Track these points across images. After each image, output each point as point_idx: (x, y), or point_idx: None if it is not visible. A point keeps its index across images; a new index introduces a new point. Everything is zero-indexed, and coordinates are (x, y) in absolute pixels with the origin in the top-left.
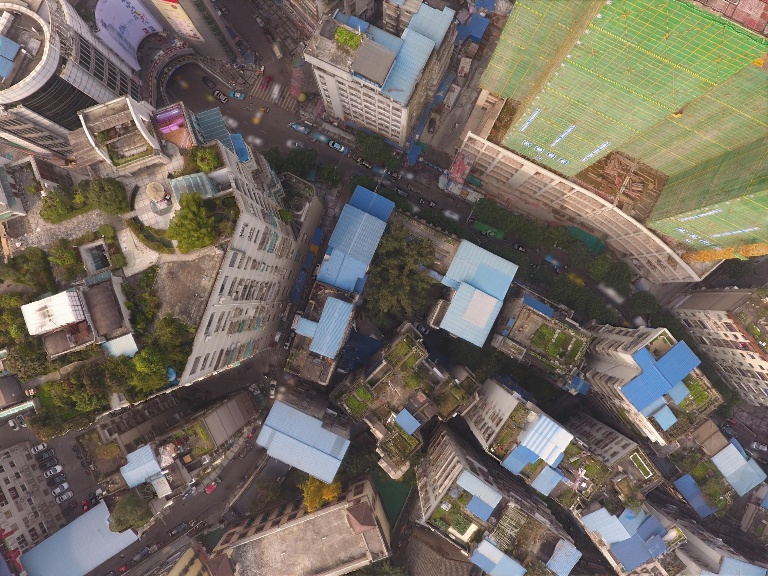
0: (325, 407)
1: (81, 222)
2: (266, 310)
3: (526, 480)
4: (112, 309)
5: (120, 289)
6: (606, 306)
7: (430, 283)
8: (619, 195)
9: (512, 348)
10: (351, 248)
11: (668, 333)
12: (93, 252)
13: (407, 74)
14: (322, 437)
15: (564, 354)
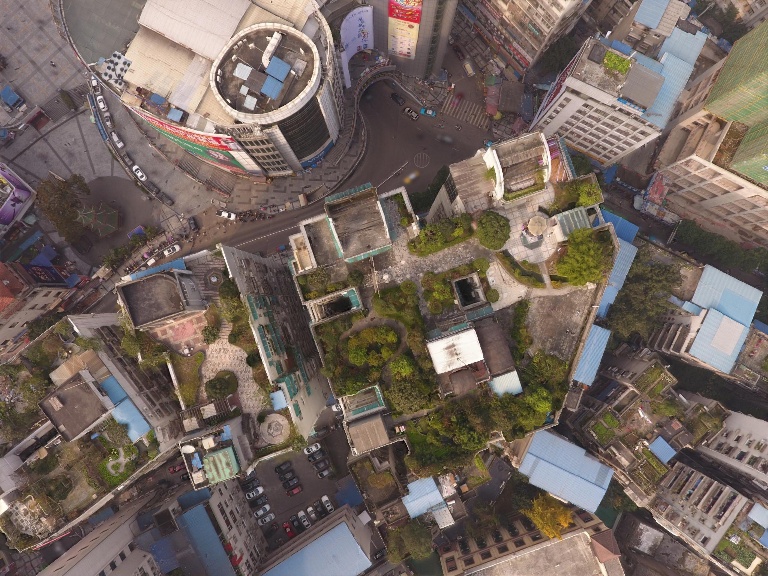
0: (557, 432)
1: (447, 255)
2: None
3: None
4: (506, 346)
5: None
6: None
7: (667, 308)
8: None
9: (746, 374)
10: None
11: None
12: None
13: (665, 98)
14: (586, 466)
15: None
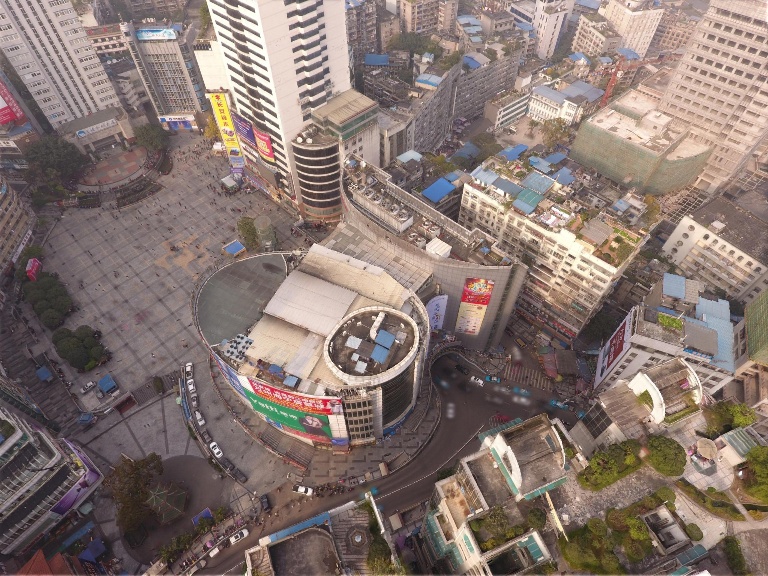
0: None
1: (622, 488)
2: None
3: None
4: None
5: None
6: None
7: None
8: None
9: None
10: None
11: None
12: None
13: (723, 348)
14: None
15: None
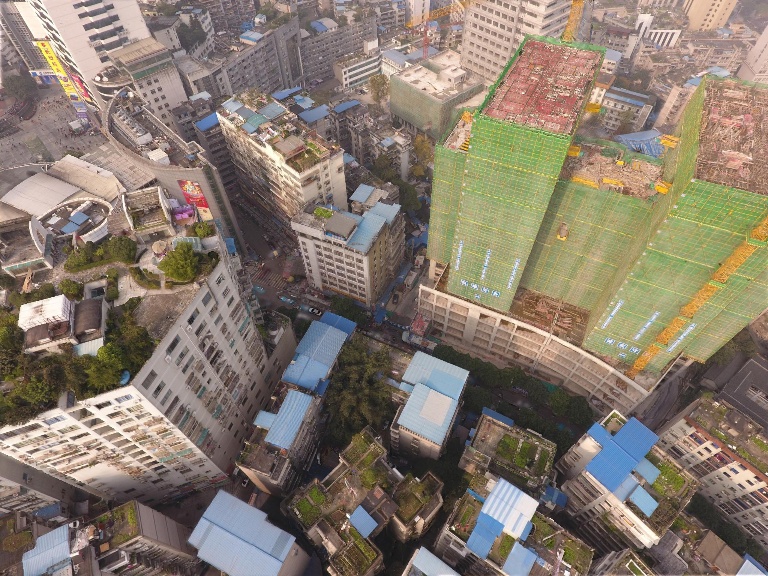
0: None
1: (93, 272)
2: (229, 406)
3: (499, 573)
4: (95, 315)
5: (106, 311)
6: (576, 441)
7: (389, 392)
8: (553, 326)
9: (476, 456)
10: (315, 353)
11: (619, 414)
12: (94, 293)
13: (366, 235)
14: (264, 532)
15: (532, 464)
